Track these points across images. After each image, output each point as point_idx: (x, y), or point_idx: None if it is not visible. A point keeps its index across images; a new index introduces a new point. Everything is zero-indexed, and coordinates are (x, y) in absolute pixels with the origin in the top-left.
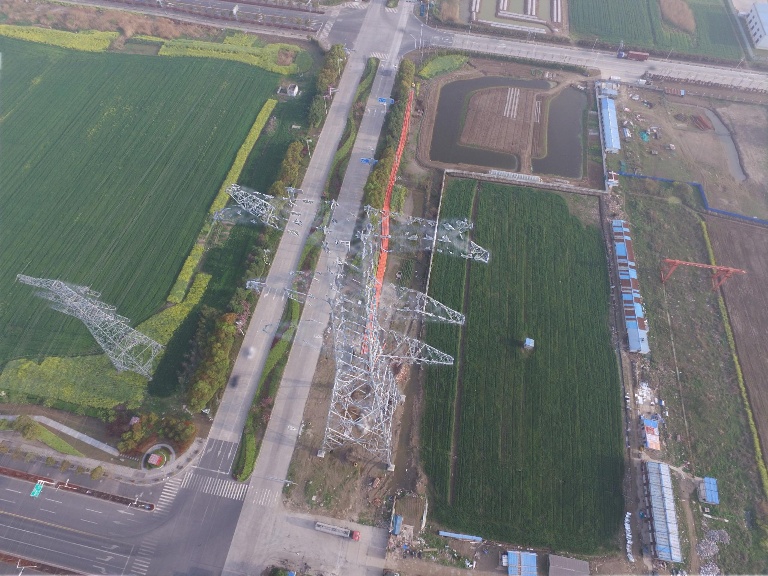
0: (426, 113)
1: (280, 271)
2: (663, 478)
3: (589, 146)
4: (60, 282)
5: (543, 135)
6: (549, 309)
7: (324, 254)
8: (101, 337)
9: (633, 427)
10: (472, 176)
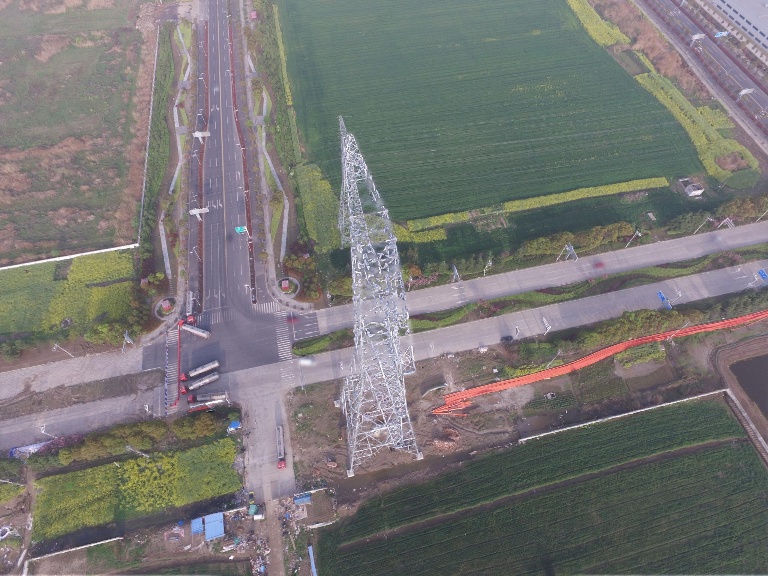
0: None
1: (484, 286)
2: None
3: None
4: None
5: None
6: None
7: (526, 314)
8: None
9: None
10: (747, 426)
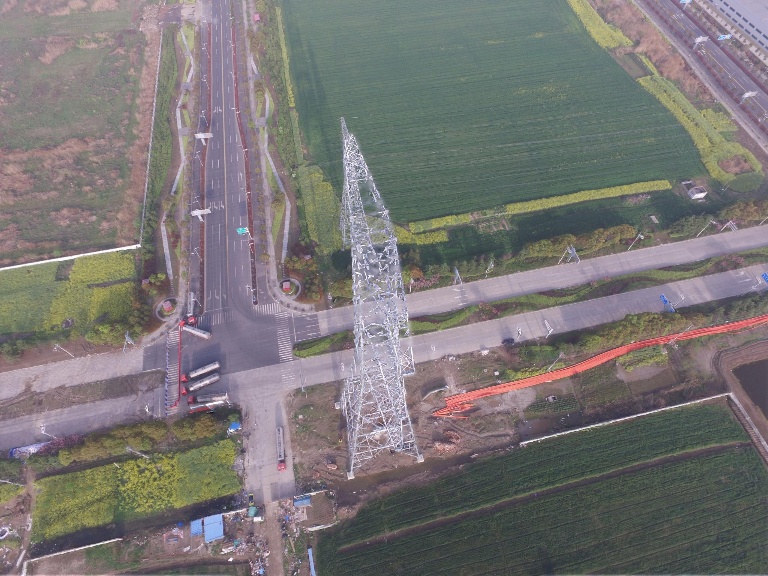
0: None
1: (485, 288)
2: None
3: None
4: None
5: None
6: None
7: (527, 316)
8: None
9: None
10: (751, 430)
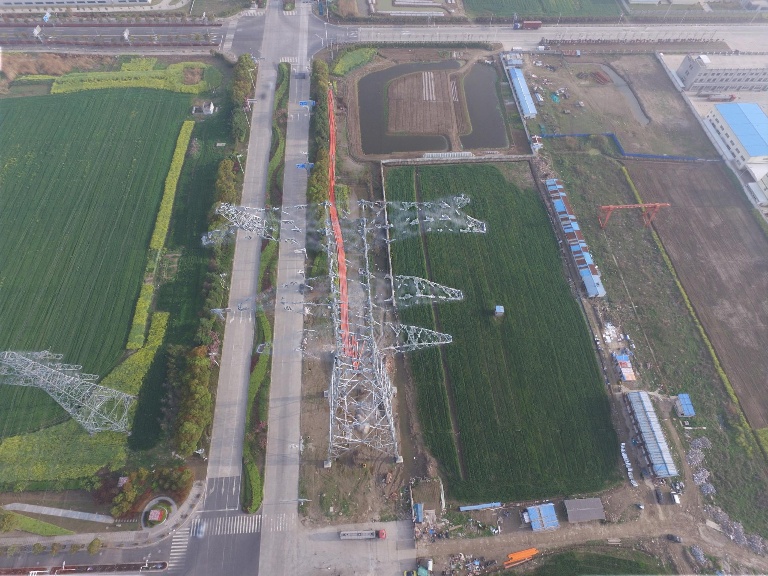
0: (349, 109)
1: (240, 293)
2: (645, 404)
3: (509, 115)
4: (12, 352)
5: (465, 112)
6: (509, 274)
7: (282, 267)
8: (66, 402)
9: (608, 365)
10: (408, 163)
